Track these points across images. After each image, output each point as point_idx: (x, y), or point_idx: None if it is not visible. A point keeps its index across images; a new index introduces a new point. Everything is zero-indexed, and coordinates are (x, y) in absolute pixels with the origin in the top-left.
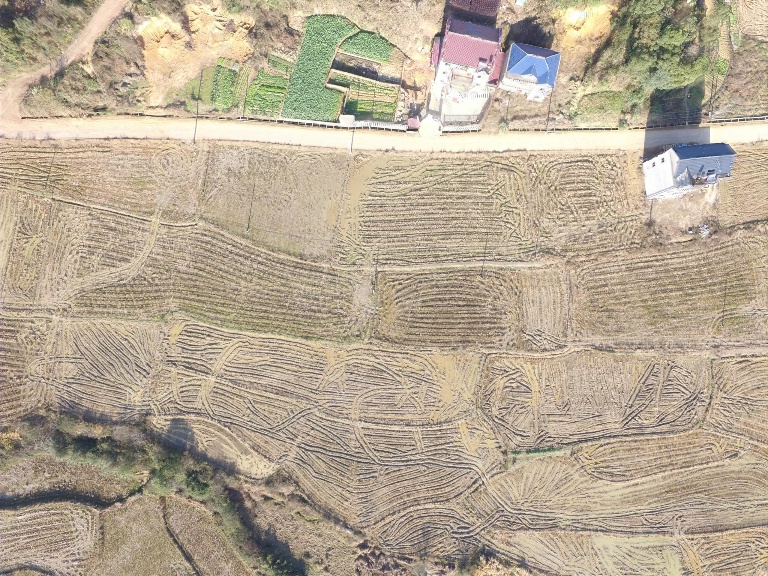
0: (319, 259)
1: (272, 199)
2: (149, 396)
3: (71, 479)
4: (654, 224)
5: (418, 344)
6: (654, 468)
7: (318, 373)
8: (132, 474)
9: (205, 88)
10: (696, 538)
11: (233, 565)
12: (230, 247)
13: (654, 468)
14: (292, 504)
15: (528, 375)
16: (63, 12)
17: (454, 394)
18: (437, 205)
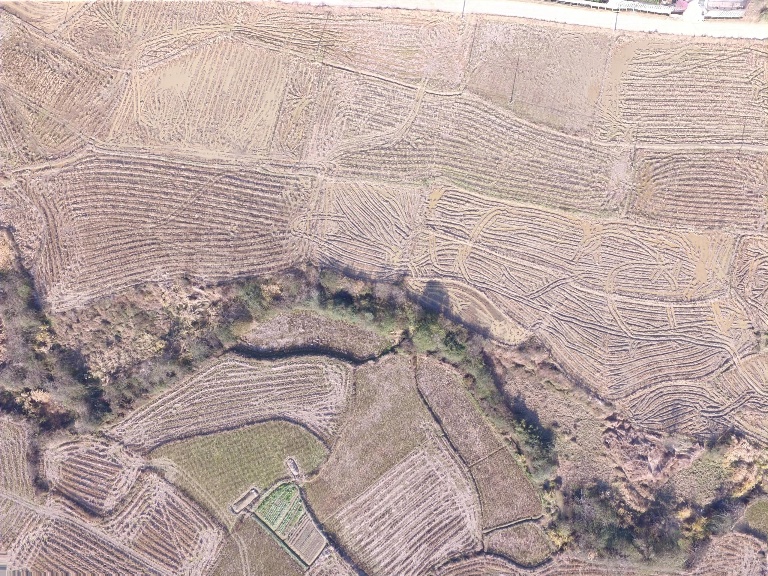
0: (580, 133)
1: (535, 74)
2: (408, 257)
3: (324, 336)
4: None
5: (674, 221)
6: None
7: (574, 244)
8: (386, 333)
9: None
10: None
11: (481, 430)
12: (492, 117)
13: None
14: (544, 372)
15: None
16: None
17: (708, 273)
18: (697, 87)
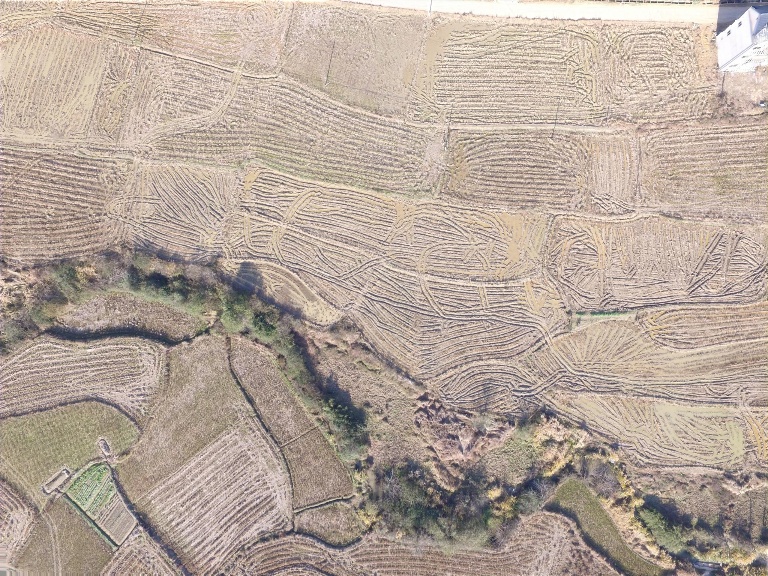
0: (394, 115)
1: (351, 56)
2: (222, 239)
3: (140, 317)
4: (726, 95)
5: (487, 201)
6: (720, 337)
7: (387, 225)
8: (200, 314)
9: None
10: (761, 411)
11: (294, 410)
12: (308, 100)
13: (720, 337)
14: (355, 352)
15: (595, 238)
16: None
17: (521, 252)
18: (511, 68)
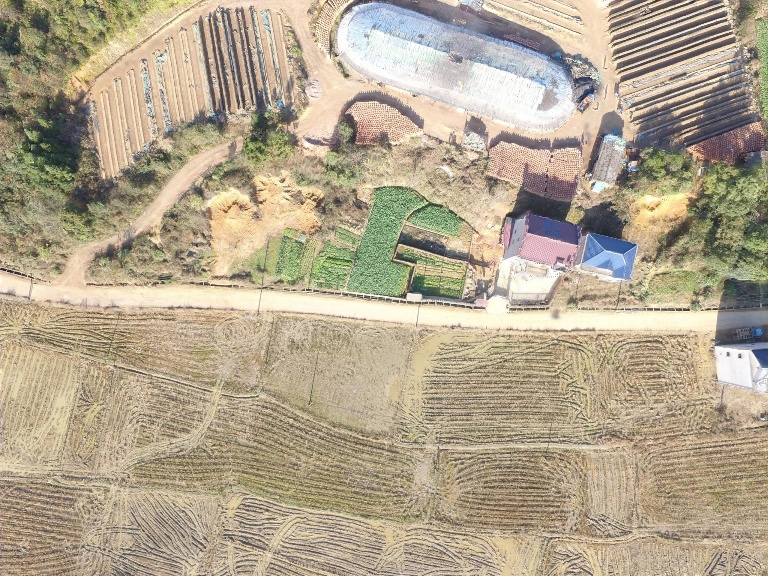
0: (381, 436)
1: (335, 373)
2: (205, 570)
3: None
4: (725, 410)
5: (479, 526)
6: None
7: (376, 552)
8: None
9: (271, 259)
10: None
11: None
12: (291, 420)
13: None
14: None
15: (591, 561)
16: (135, 192)
17: None
18: (502, 383)
